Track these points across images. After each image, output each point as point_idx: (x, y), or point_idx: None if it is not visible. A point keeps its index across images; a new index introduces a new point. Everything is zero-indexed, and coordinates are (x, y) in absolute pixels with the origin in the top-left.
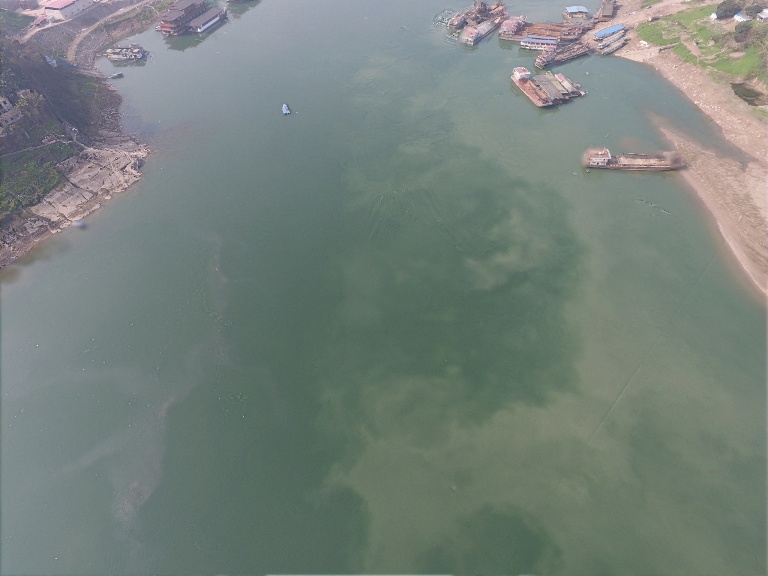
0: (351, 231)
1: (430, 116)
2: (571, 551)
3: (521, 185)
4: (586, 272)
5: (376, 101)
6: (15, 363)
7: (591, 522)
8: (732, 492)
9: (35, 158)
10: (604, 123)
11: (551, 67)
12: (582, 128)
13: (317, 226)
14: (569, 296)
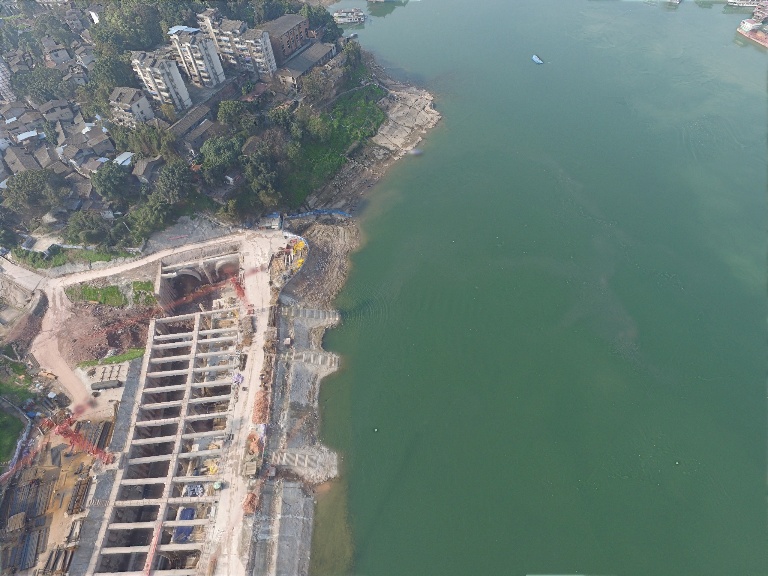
0: (675, 153)
1: (684, 62)
2: None
3: None
4: None
5: (623, 51)
6: (443, 254)
7: None
8: None
9: (362, 97)
10: None
11: None
12: None
13: (640, 150)
14: None
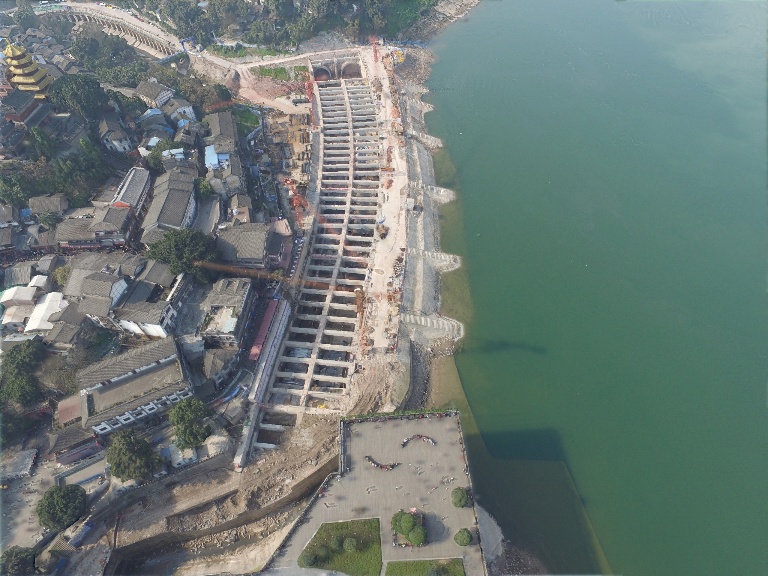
0: (642, 22)
1: None
2: None
3: (736, 5)
4: None
5: None
6: (491, 65)
7: None
8: None
9: None
10: None
11: None
12: None
13: (619, 20)
14: None
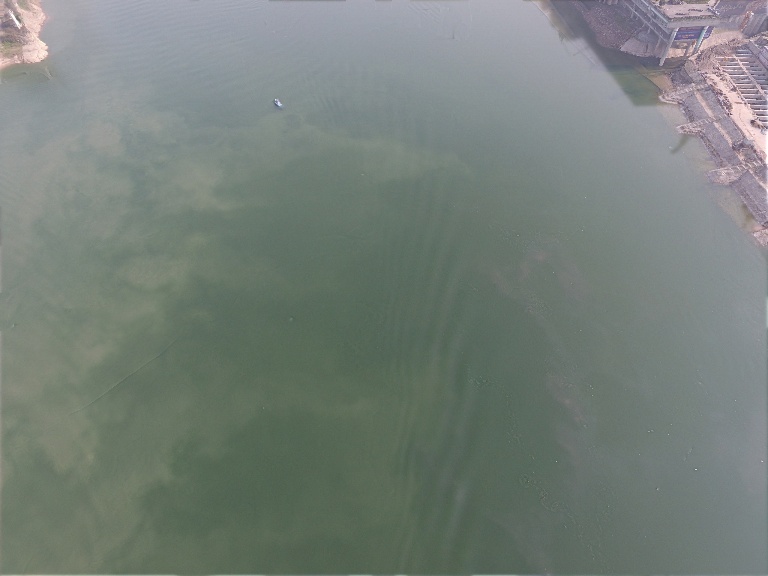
0: None
1: None
2: (227, 289)
3: None
4: (13, 570)
5: None
6: (766, 438)
7: (205, 300)
8: (95, 314)
9: None
10: None
11: None
12: None
13: None
14: (71, 519)
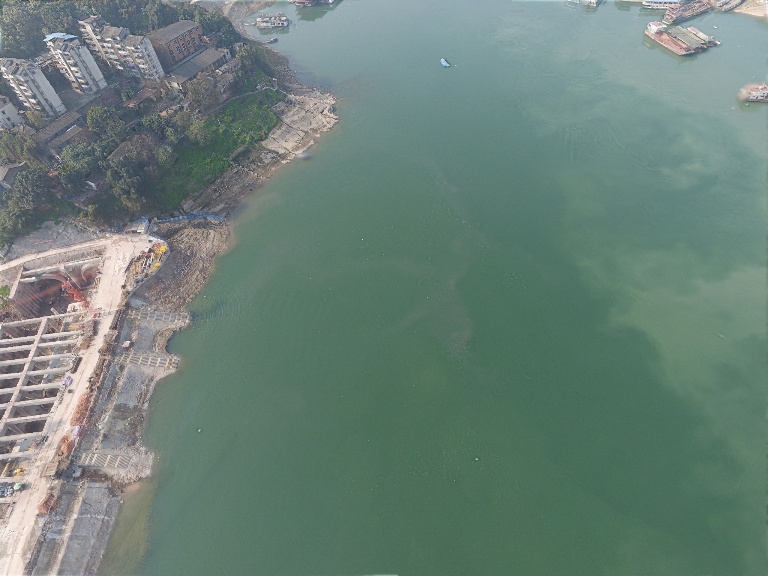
0: (553, 155)
1: (584, 64)
2: None
3: (694, 115)
4: None
5: (528, 54)
6: (306, 257)
7: None
8: None
9: (255, 101)
10: (747, 67)
11: (678, 23)
12: (726, 72)
13: (520, 152)
14: (764, 201)
